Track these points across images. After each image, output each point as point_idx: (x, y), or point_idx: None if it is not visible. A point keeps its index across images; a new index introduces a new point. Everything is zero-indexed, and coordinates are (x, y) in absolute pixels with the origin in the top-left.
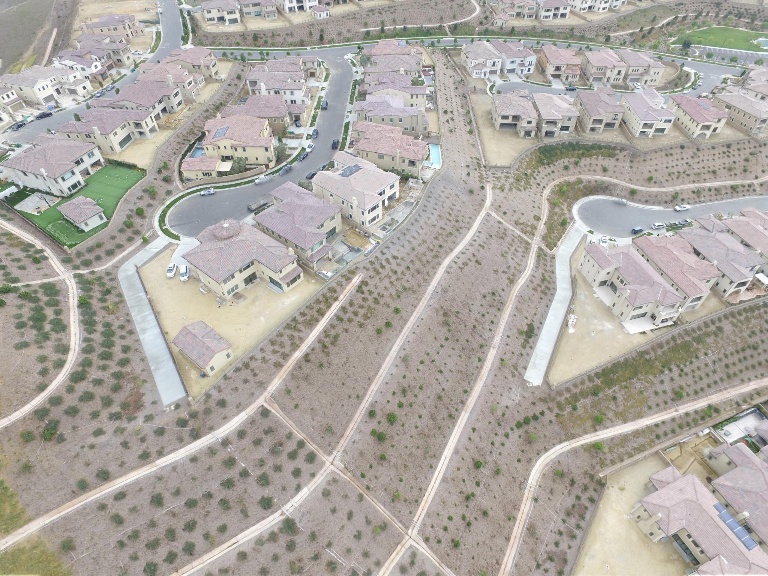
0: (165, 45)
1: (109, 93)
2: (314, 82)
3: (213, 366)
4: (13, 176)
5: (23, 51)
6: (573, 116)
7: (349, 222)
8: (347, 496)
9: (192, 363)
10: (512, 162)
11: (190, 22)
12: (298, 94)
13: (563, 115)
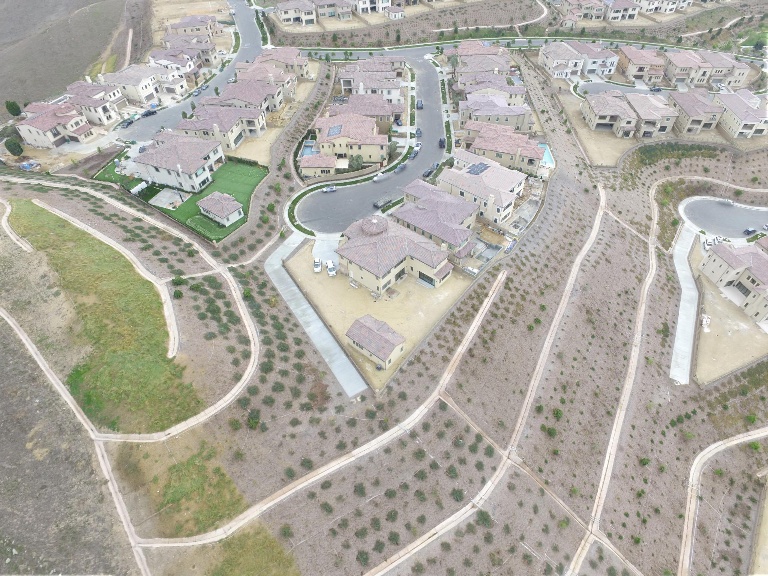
0: (246, 45)
1: (205, 92)
2: (402, 82)
3: (390, 359)
4: (143, 172)
5: (101, 51)
6: (672, 116)
7: (480, 219)
8: (530, 490)
9: (364, 356)
10: (618, 162)
11: (265, 23)
12: (395, 93)
13: (662, 115)
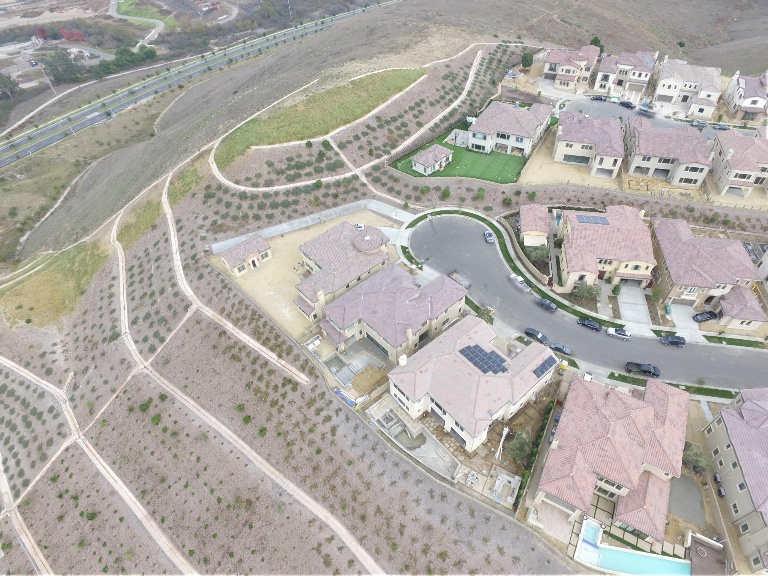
0: None
1: (709, 130)
2: None
3: None
4: None
5: None
6: None
7: None
8: (117, 379)
9: None
10: None
11: None
12: None
13: None
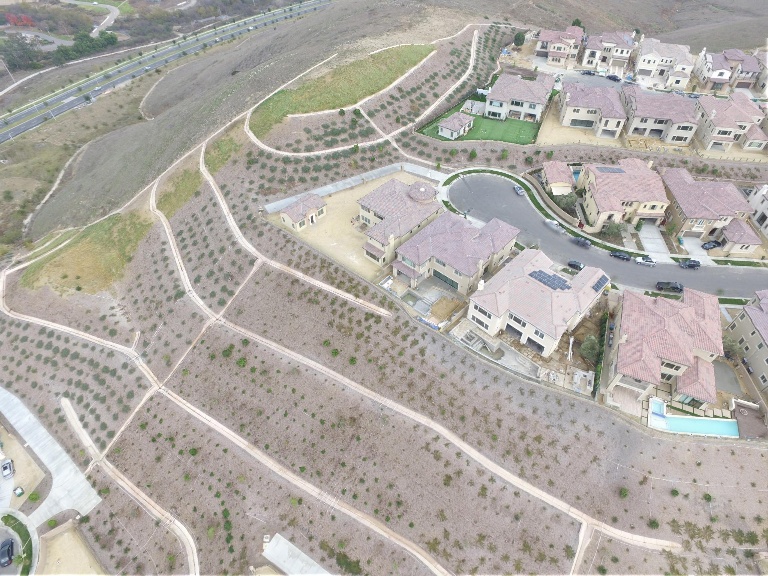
0: None
1: None
2: None
3: (285, 219)
4: None
5: (767, 44)
6: None
7: None
8: (191, 331)
9: None
10: None
11: None
12: None
13: None
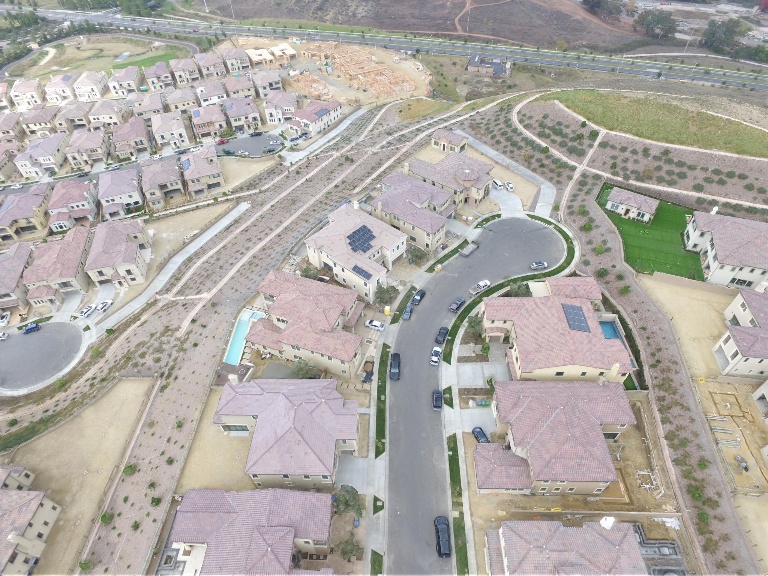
0: None
1: None
2: None
3: None
4: None
5: None
6: None
7: None
8: None
9: None
10: None
11: None
12: None
13: None
